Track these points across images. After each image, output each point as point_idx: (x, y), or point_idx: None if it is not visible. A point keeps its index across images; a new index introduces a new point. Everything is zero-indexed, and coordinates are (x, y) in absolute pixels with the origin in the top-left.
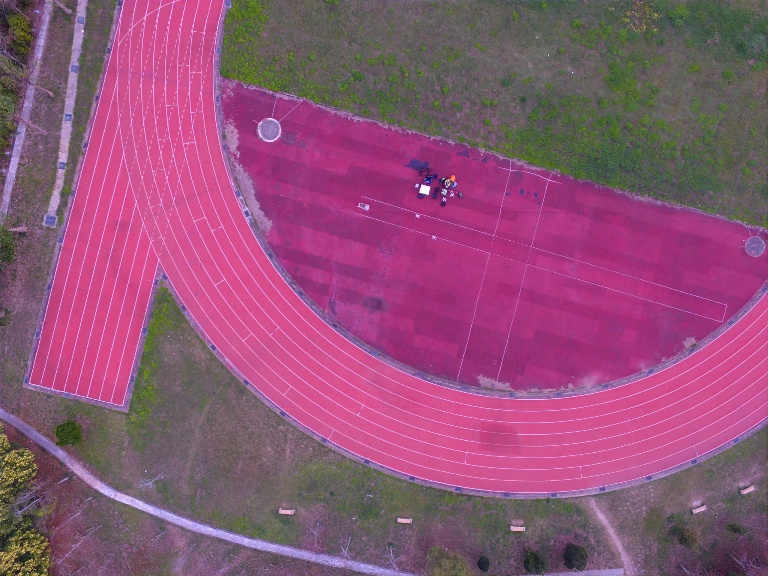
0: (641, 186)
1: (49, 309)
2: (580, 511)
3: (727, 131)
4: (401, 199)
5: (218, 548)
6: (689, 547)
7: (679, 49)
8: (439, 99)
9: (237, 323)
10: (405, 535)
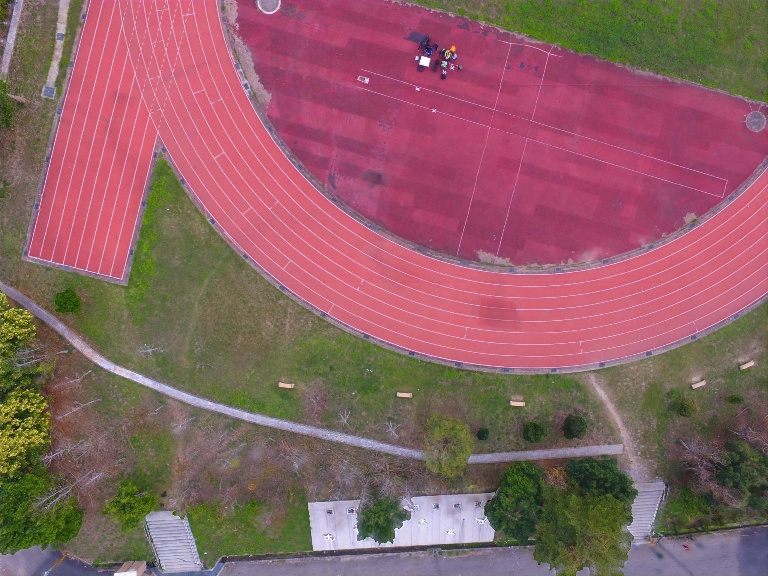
0: (642, 60)
1: (48, 181)
2: (580, 386)
3: (728, 5)
4: (401, 72)
5: (218, 422)
6: (688, 415)
7: None
8: None
9: (236, 197)
10: (405, 410)
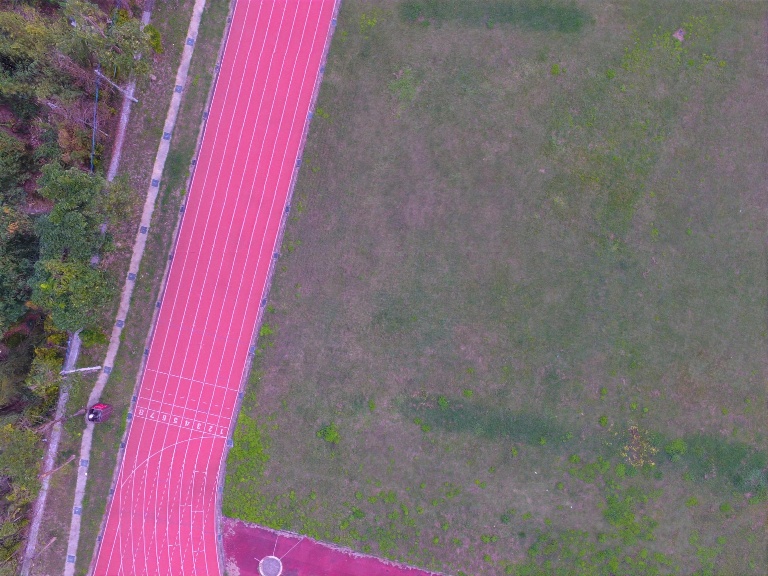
0: None
1: None
2: None
3: (725, 563)
4: None
5: None
6: None
7: (677, 483)
8: (439, 536)
9: None
10: None
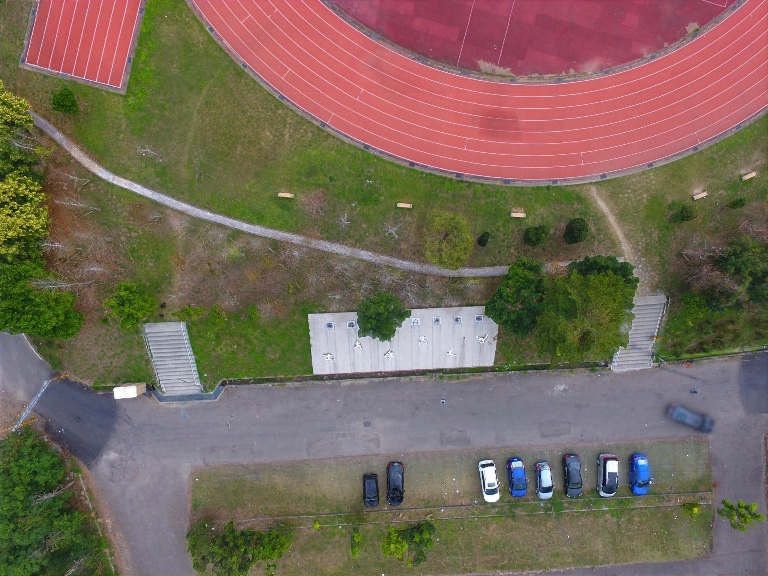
0: None
1: None
2: (581, 198)
3: None
4: None
5: (217, 233)
6: (690, 215)
7: None
8: None
9: (235, 4)
10: (405, 221)
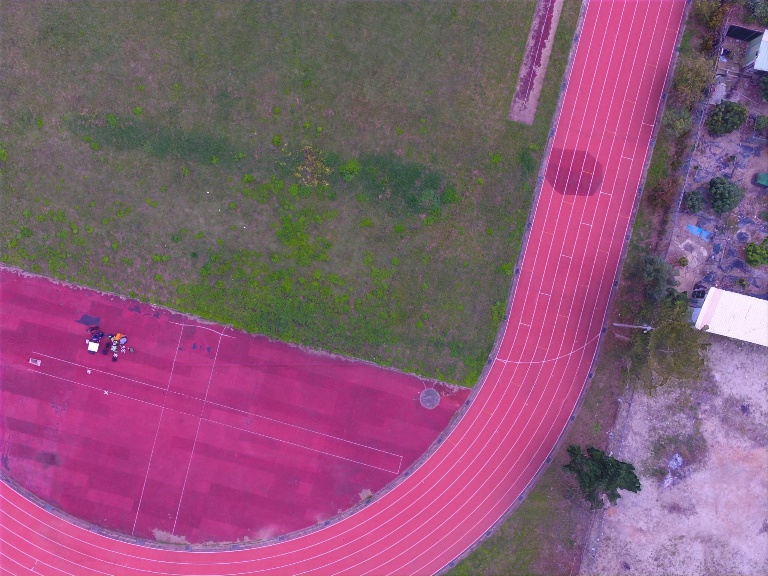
0: (314, 340)
1: None
2: None
3: (400, 285)
4: (73, 354)
5: None
6: None
7: (351, 203)
8: (109, 255)
9: None
10: None
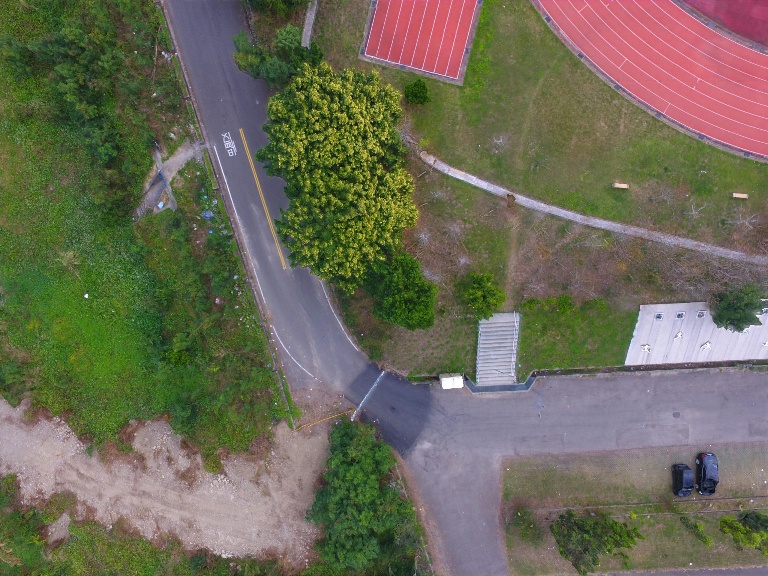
0: None
1: None
2: None
3: None
4: None
5: (551, 224)
6: None
7: None
8: None
9: None
10: (739, 212)
